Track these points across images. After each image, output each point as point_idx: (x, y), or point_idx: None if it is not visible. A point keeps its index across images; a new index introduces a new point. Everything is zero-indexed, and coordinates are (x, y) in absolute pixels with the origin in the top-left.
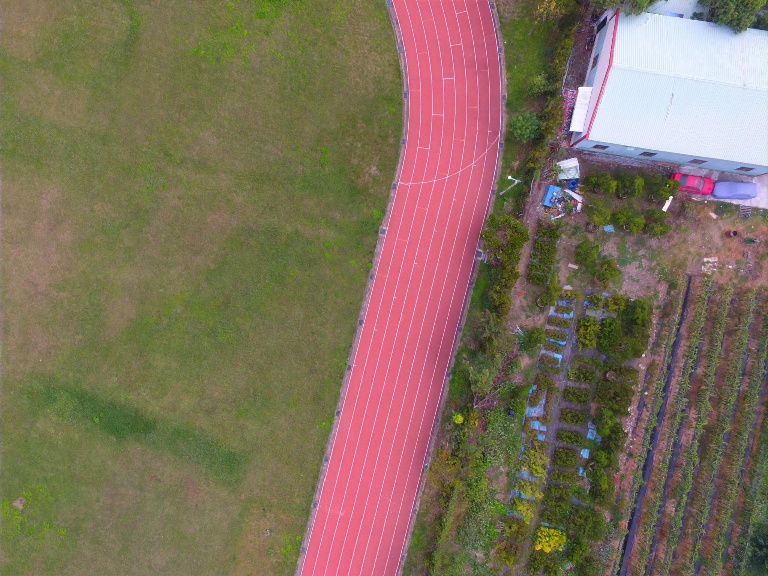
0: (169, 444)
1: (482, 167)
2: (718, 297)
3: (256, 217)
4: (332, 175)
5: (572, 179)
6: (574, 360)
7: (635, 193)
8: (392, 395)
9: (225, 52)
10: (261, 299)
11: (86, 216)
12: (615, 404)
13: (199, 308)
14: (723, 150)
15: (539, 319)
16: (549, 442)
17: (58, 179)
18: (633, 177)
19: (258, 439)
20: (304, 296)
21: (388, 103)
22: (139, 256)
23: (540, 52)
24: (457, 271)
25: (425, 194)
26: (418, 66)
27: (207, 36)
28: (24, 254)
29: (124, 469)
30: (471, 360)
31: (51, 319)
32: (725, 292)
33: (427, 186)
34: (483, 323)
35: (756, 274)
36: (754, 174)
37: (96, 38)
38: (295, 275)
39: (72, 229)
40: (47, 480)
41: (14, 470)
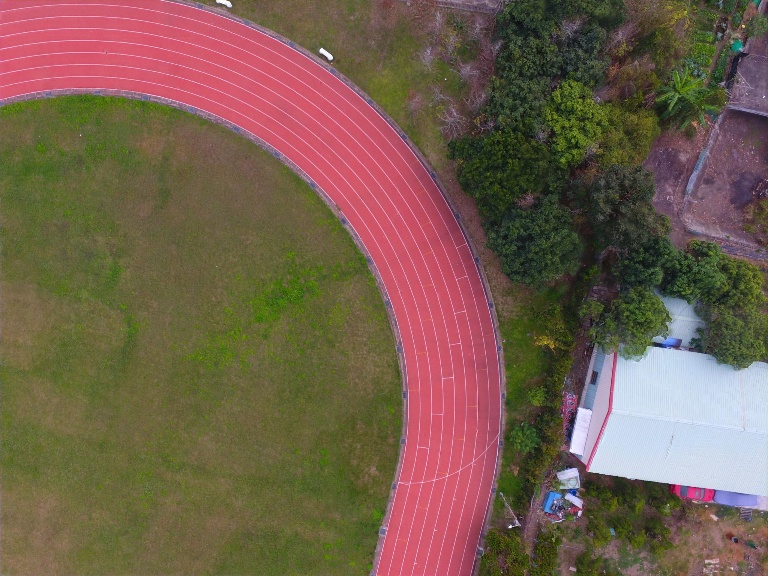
0: None
1: (482, 466)
2: None
3: (255, 521)
4: (331, 477)
5: (572, 489)
6: None
7: (636, 512)
8: None
9: (223, 357)
10: None
11: (84, 524)
12: None
13: None
14: (723, 483)
15: None
16: None
17: (56, 488)
18: (633, 490)
19: None
20: None
21: (387, 404)
22: (138, 563)
23: (539, 353)
24: (458, 570)
25: (425, 494)
26: (417, 366)
27: (205, 341)
28: (22, 564)
29: None
30: None
31: None
32: None
33: (427, 486)
34: None
35: None
36: None
37: (94, 346)
38: None
39: (70, 538)
40: None
41: None
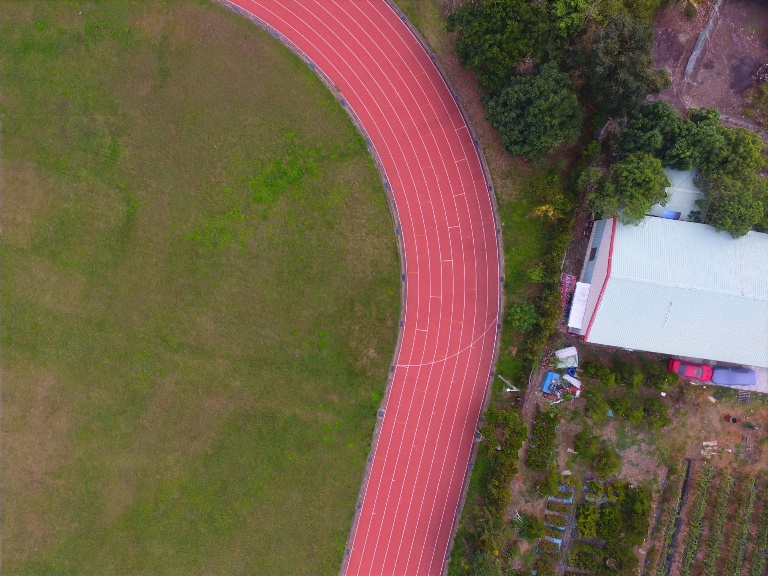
0: None
1: (480, 349)
2: (718, 482)
3: (253, 402)
4: (330, 358)
5: (571, 368)
6: (574, 548)
7: (634, 387)
8: None
9: (222, 237)
10: (259, 484)
11: (82, 403)
12: None
13: (196, 494)
14: (722, 353)
15: (538, 504)
16: None
17: (54, 366)
18: (632, 367)
19: None
20: (302, 480)
21: (386, 286)
22: (136, 442)
23: (538, 235)
24: (456, 453)
25: (423, 376)
26: (416, 249)
27: (204, 221)
28: (20, 442)
29: None
30: (470, 544)
31: (47, 507)
32: (725, 481)
33: (425, 368)
34: (482, 523)
35: (755, 458)
36: None
37: (92, 225)
38: (293, 459)
39: (68, 416)
40: None
41: None
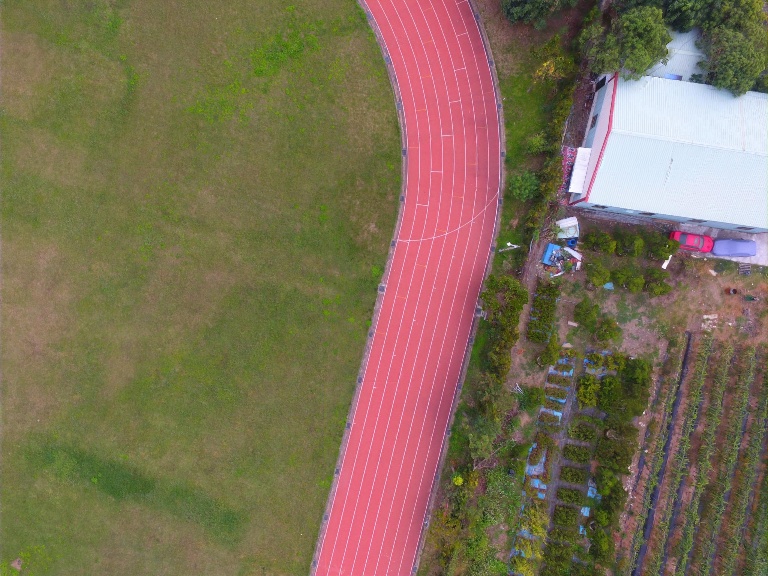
0: (168, 504)
1: (481, 224)
2: (718, 354)
3: (255, 275)
4: (331, 233)
5: (571, 238)
6: (574, 419)
7: (634, 253)
8: (392, 453)
9: (223, 110)
10: (260, 357)
11: (84, 275)
12: (615, 463)
13: (198, 367)
14: (722, 213)
15: (539, 377)
16: (549, 500)
17: (56, 238)
18: (632, 236)
19: (257, 498)
20: (303, 354)
21: (387, 160)
22: (137, 315)
23: (539, 109)
24: (456, 328)
25: (424, 251)
26: (417, 123)
27: (205, 94)
28: (22, 314)
29: (123, 529)
30: (471, 418)
31: (49, 379)
32: (725, 351)
33: (426, 243)
34: (483, 386)
35: (756, 331)
36: (754, 232)
37: (93, 97)
38: (294, 333)
39: (70, 288)
40: (45, 541)
41: (12, 531)
